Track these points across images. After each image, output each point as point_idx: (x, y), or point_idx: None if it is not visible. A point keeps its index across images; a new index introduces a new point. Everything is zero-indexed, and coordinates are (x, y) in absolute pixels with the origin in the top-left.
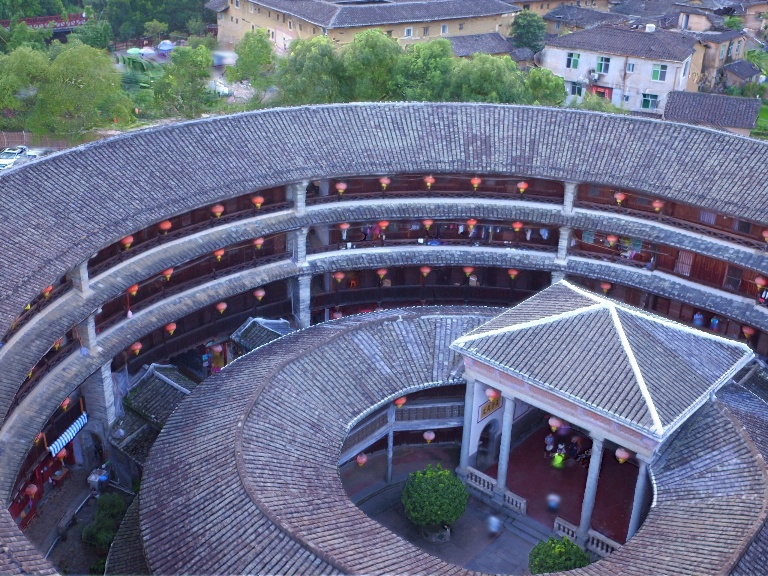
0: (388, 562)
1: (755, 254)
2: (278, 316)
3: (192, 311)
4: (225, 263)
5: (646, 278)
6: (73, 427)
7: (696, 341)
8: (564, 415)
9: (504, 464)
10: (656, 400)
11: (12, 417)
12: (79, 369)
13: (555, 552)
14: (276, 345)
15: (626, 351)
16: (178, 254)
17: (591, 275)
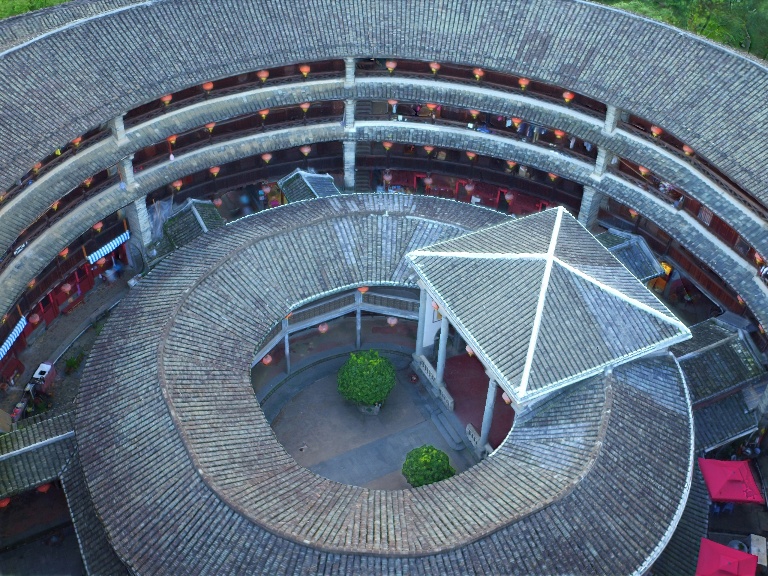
0: (231, 441)
1: (762, 227)
2: (329, 169)
3: (232, 160)
4: (283, 115)
5: (669, 216)
6: (114, 242)
7: (628, 310)
8: (473, 347)
9: (440, 365)
10: (537, 363)
11: (41, 237)
12: (113, 201)
13: (421, 460)
14: (280, 211)
15: (537, 308)
16: (220, 111)
17: (618, 199)
